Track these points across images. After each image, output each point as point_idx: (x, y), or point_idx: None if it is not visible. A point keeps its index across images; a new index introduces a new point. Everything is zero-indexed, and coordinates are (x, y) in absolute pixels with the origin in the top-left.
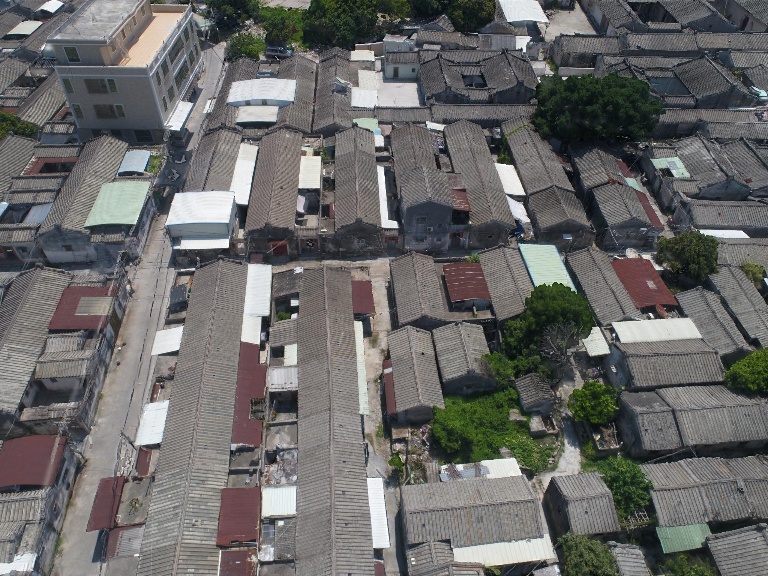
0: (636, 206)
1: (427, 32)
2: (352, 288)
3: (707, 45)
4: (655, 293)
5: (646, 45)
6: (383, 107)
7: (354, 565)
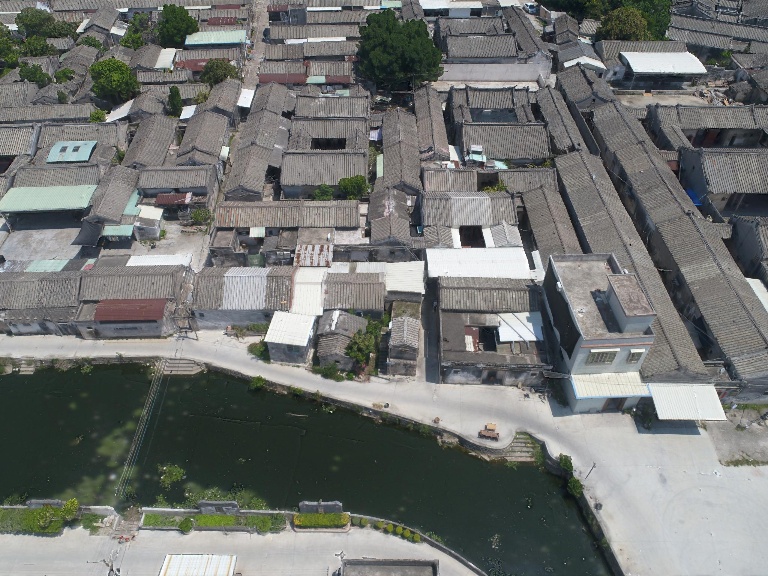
0: (279, 68)
1: (564, 18)
2: (234, 5)
3: (623, 156)
4: (194, 63)
5: (601, 118)
6: (412, 4)
7: (95, 4)
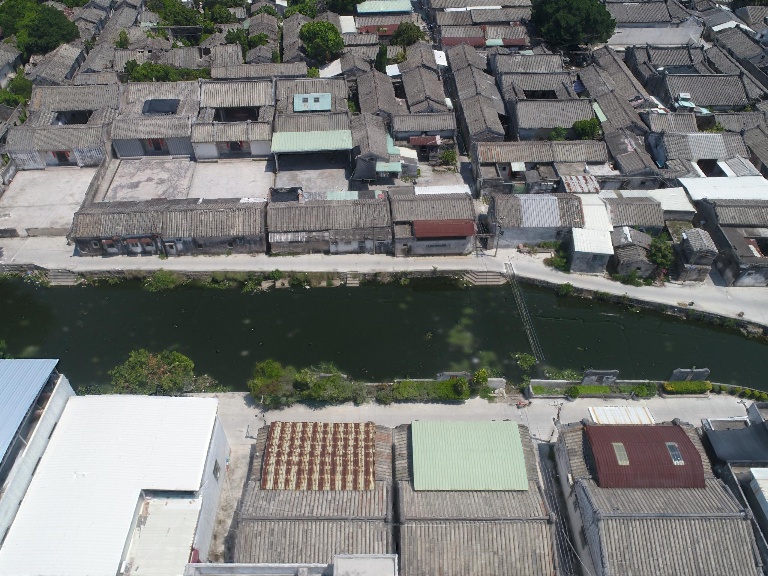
0: (459, 32)
1: None
2: None
3: None
4: (376, 28)
5: None
6: None
7: None
